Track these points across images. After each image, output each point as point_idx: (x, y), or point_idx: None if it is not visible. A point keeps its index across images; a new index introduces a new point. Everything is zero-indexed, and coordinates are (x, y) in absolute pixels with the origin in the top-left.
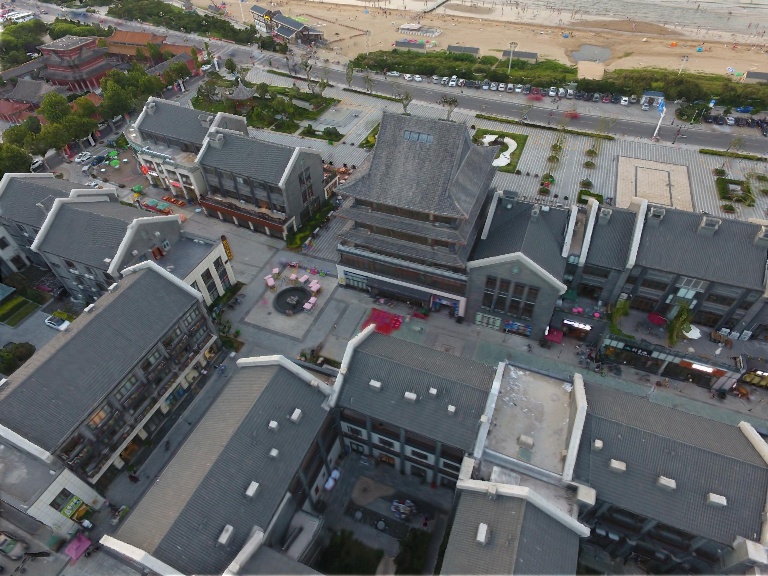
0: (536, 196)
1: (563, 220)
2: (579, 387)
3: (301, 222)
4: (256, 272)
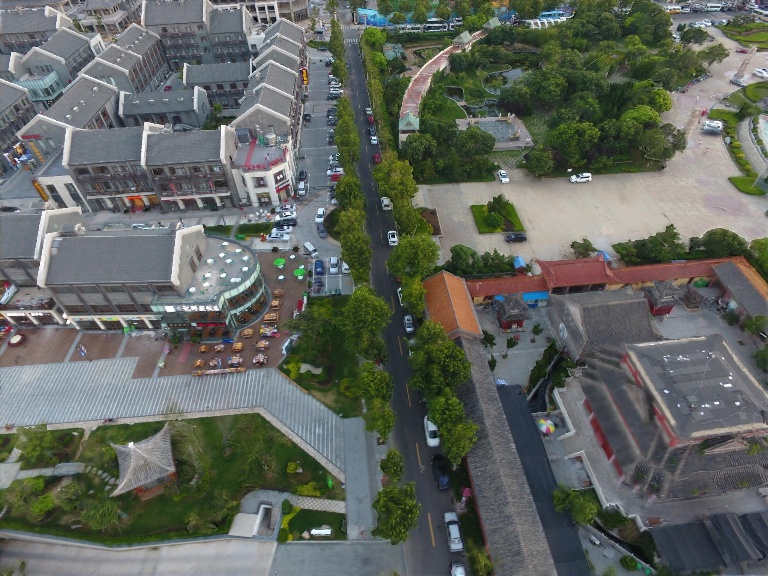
0: None
1: None
2: None
3: None
4: None
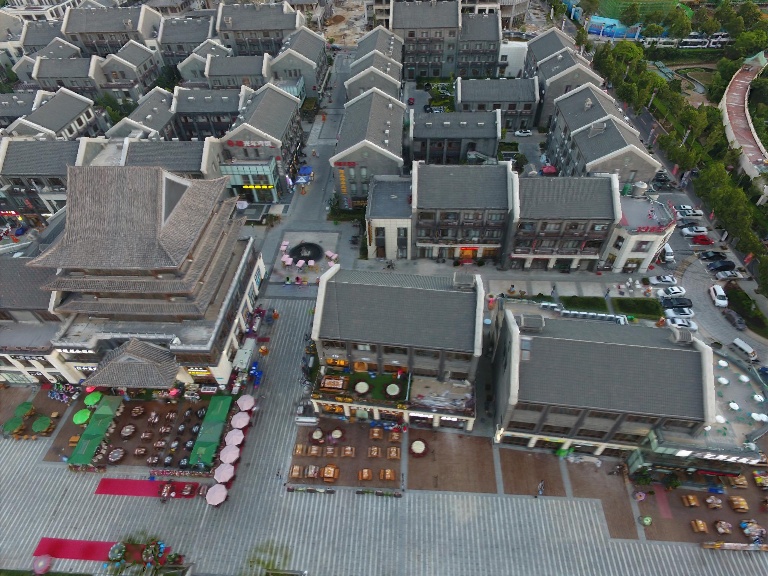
0: None
1: None
2: (80, 156)
3: None
4: None
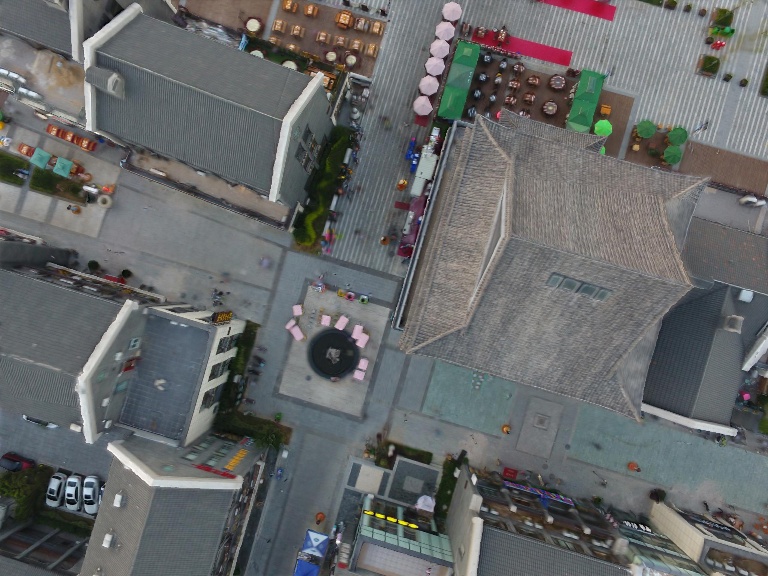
0: (693, 79)
1: (767, 313)
2: None
3: (306, 190)
4: (267, 301)
